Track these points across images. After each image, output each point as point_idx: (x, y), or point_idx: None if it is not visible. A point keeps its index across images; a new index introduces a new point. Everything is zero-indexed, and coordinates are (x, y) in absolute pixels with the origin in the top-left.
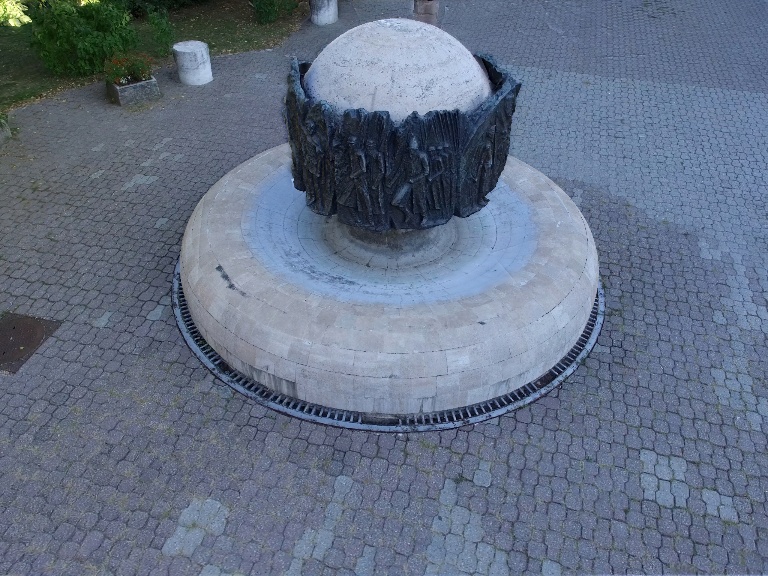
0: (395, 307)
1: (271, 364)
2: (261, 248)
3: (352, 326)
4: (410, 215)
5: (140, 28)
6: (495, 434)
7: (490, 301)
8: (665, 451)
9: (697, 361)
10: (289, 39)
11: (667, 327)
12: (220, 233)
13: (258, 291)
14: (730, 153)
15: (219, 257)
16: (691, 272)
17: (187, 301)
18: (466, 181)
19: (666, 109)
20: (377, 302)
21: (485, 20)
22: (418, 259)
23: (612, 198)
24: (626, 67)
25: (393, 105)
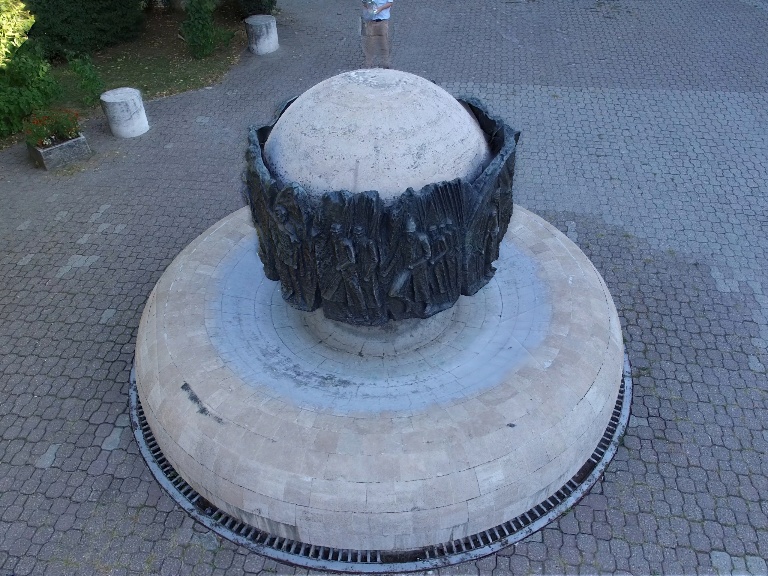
0: (405, 415)
1: (264, 507)
2: (233, 351)
3: (358, 450)
4: (411, 304)
5: (60, 77)
6: (541, 555)
7: (515, 394)
8: (738, 550)
9: (745, 424)
10: (229, 73)
11: (703, 384)
12: (181, 338)
13: (237, 414)
14: (719, 163)
15: (183, 371)
16: (712, 310)
17: (150, 426)
18: (472, 256)
19: (642, 118)
20: (382, 410)
21: (435, 34)
22: (417, 339)
23: (609, 229)
24: (591, 74)
25: (380, 180)
